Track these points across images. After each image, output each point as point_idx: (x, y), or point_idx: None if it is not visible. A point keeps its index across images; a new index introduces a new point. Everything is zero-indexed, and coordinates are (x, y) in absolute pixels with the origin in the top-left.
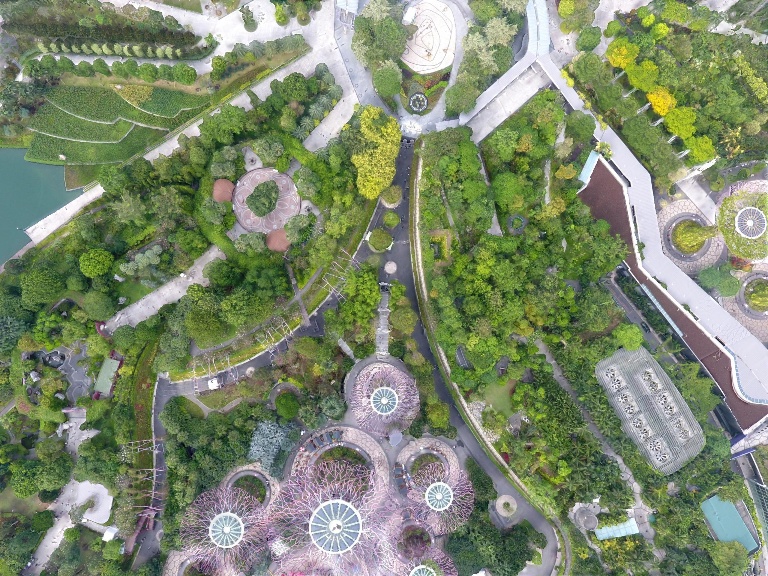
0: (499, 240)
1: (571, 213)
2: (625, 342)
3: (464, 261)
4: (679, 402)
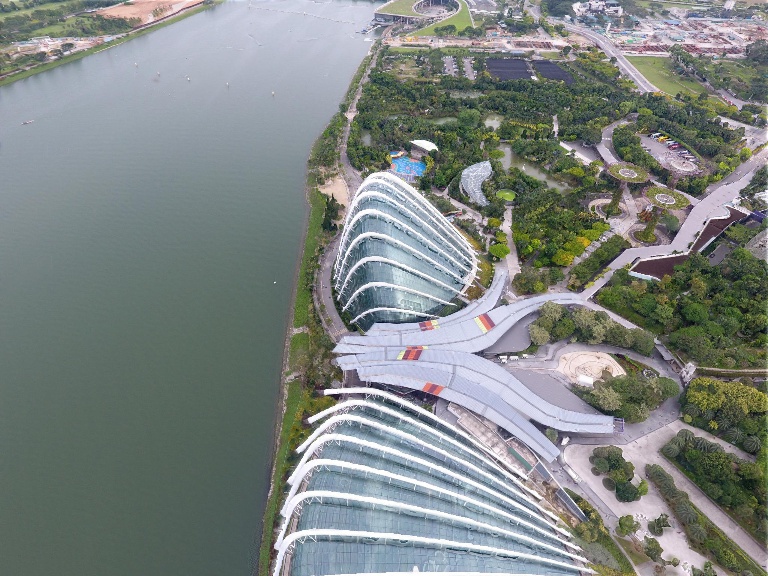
0: (736, 316)
1: (684, 281)
2: (750, 256)
3: (766, 337)
4: (762, 235)
